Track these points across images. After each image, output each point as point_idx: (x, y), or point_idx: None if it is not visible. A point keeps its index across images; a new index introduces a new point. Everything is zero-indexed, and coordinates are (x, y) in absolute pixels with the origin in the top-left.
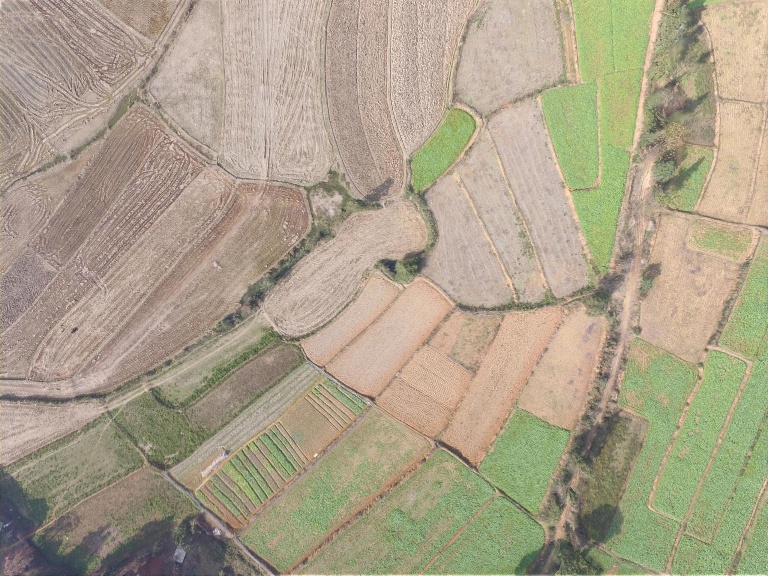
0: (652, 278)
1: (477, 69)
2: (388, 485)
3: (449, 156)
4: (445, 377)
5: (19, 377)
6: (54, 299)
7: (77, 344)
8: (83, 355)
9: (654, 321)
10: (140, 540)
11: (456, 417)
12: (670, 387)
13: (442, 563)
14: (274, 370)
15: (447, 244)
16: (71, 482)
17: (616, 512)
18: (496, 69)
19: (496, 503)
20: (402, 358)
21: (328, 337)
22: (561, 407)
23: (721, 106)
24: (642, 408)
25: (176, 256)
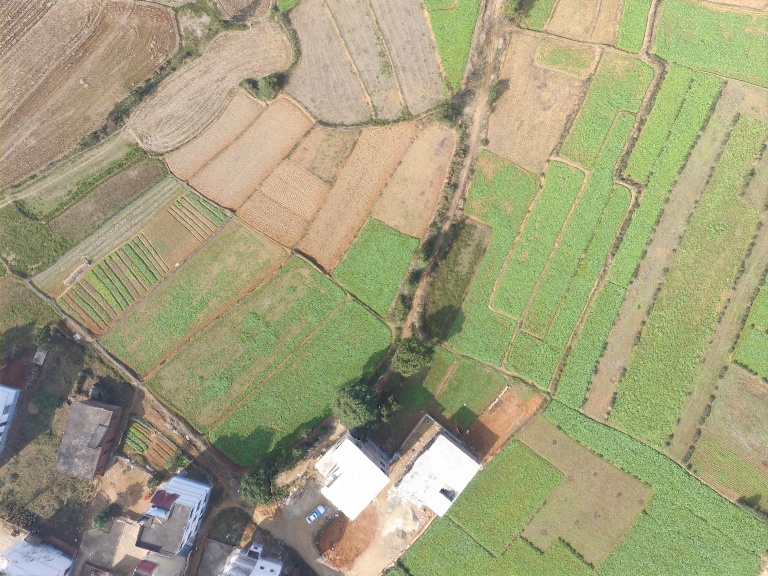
0: (501, 93)
1: None
2: (246, 292)
3: None
4: (304, 190)
5: None
6: None
7: None
8: None
9: (501, 134)
10: (1, 345)
11: (312, 227)
12: (513, 195)
13: (294, 362)
14: (138, 184)
15: (310, 63)
16: None
17: (458, 312)
18: None
19: (347, 306)
20: (263, 173)
21: (192, 152)
22: (412, 217)
23: None
24: (486, 215)
25: (42, 73)
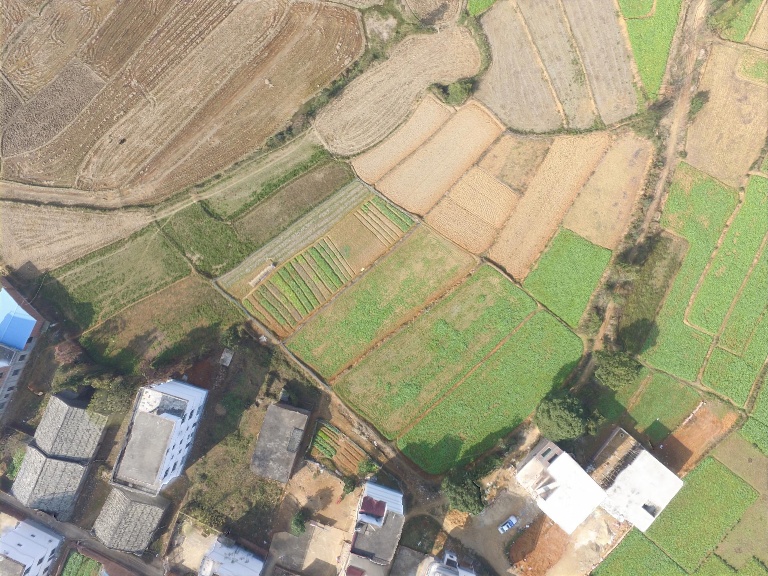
0: None
1: None
2: (433, 299)
3: None
4: (493, 198)
5: (65, 186)
6: (102, 110)
7: (125, 155)
8: (131, 167)
9: (700, 146)
10: (186, 345)
11: (502, 235)
12: (711, 209)
13: (483, 371)
14: (324, 186)
15: (500, 69)
16: (118, 288)
17: (652, 326)
18: None
19: (538, 316)
20: (451, 179)
21: (378, 156)
22: (605, 228)
23: None
24: (683, 229)
25: (227, 72)
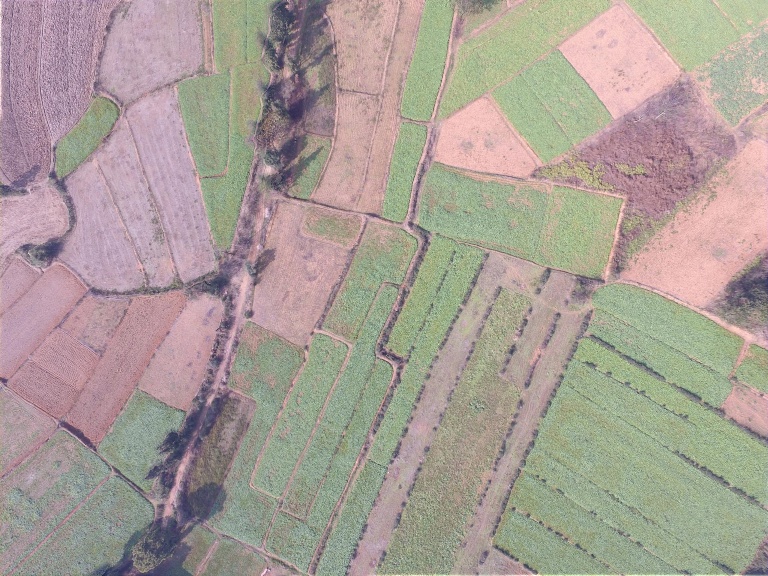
0: (266, 263)
1: (120, 58)
2: (13, 465)
3: (91, 143)
4: (74, 359)
5: None
6: None
7: None
8: None
9: (266, 305)
10: None
11: (80, 398)
12: (277, 369)
13: (55, 540)
14: None
15: (84, 229)
16: None
17: (220, 490)
18: (139, 59)
19: (110, 482)
20: (36, 341)
21: None
22: (179, 388)
23: (340, 97)
24: (250, 389)
25: None
